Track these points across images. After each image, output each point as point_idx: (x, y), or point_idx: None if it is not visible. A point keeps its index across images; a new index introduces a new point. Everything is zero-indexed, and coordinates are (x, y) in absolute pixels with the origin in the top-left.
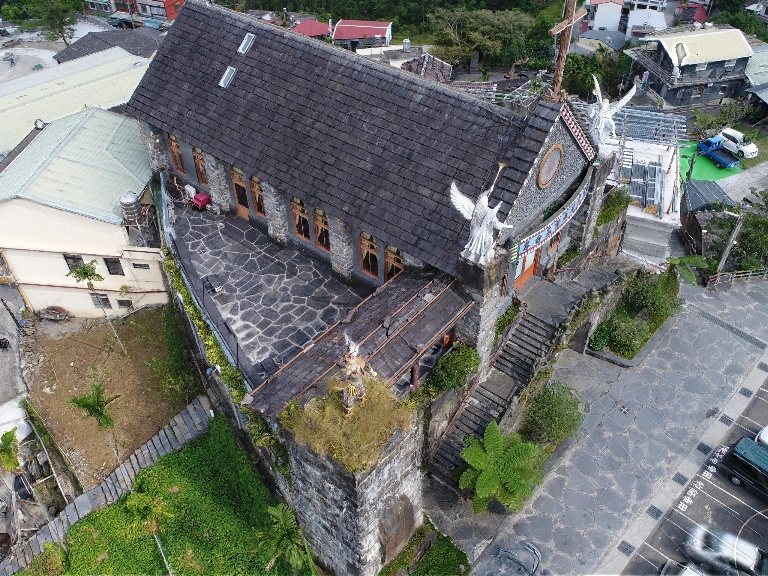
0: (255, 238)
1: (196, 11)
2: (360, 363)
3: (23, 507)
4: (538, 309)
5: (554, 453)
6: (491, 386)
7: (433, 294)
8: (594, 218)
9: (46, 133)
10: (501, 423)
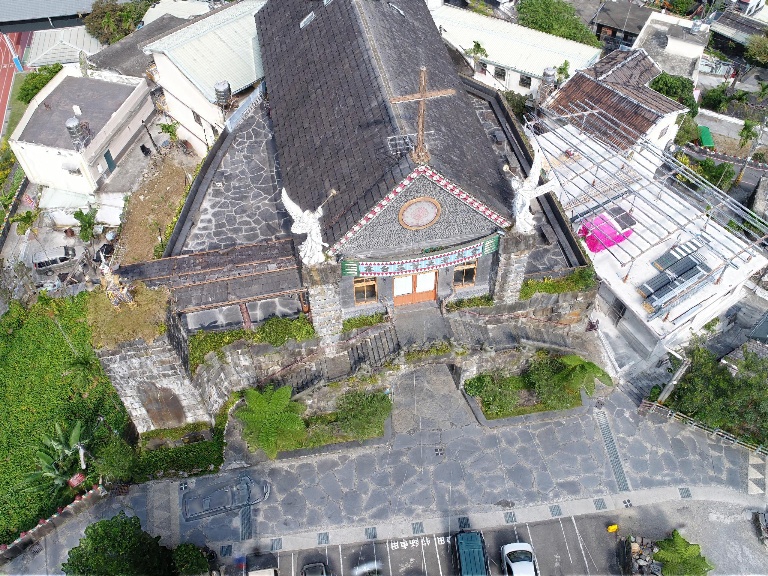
0: None
1: None
2: (116, 279)
3: (91, 265)
4: (405, 328)
5: (348, 442)
6: (331, 363)
7: (280, 266)
8: (516, 281)
9: (235, 7)
10: (303, 392)
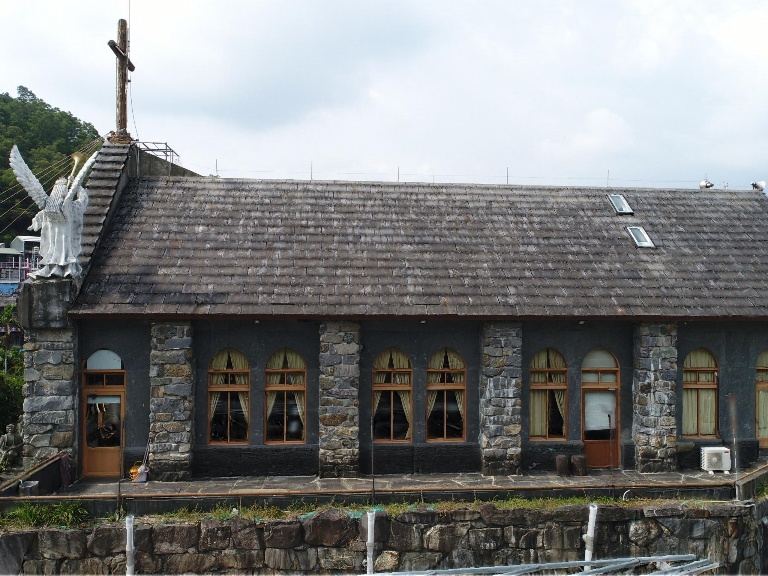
0: None
1: None
2: None
3: None
4: None
5: None
6: None
7: None
8: None
9: None
10: None
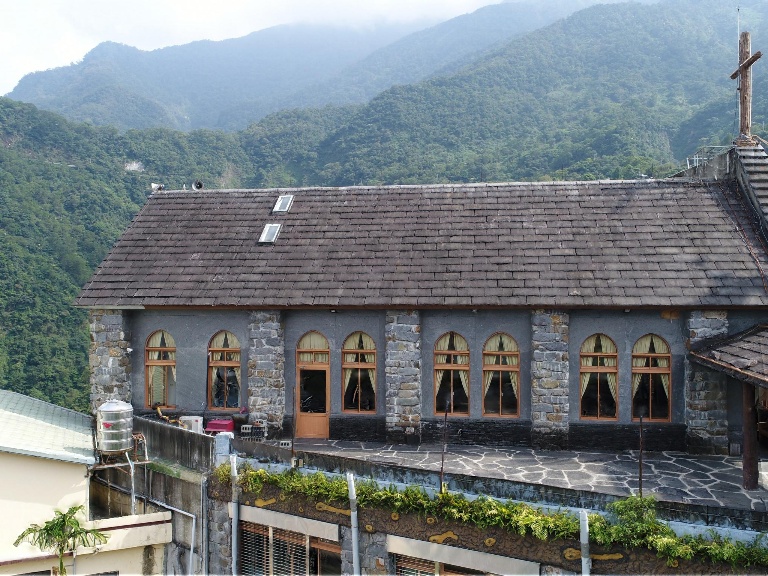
0: (358, 445)
1: (177, 197)
2: None
3: None
4: None
5: None
6: None
7: None
8: None
9: None
10: None
